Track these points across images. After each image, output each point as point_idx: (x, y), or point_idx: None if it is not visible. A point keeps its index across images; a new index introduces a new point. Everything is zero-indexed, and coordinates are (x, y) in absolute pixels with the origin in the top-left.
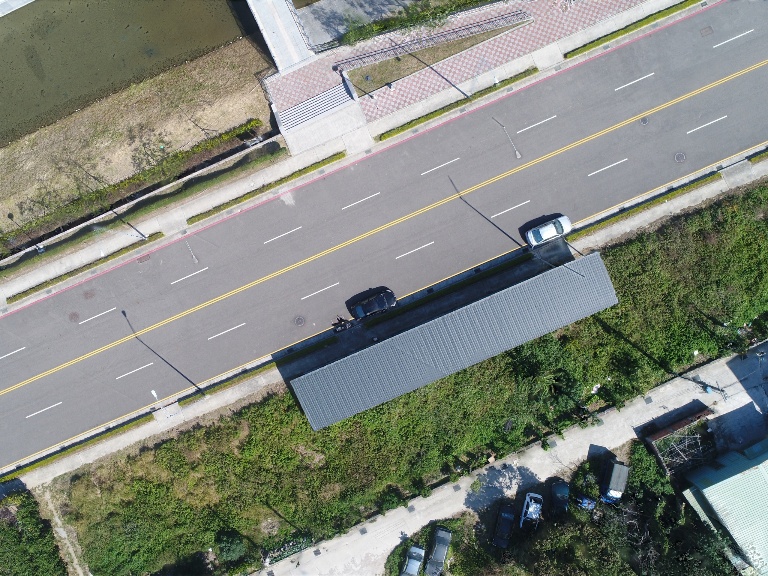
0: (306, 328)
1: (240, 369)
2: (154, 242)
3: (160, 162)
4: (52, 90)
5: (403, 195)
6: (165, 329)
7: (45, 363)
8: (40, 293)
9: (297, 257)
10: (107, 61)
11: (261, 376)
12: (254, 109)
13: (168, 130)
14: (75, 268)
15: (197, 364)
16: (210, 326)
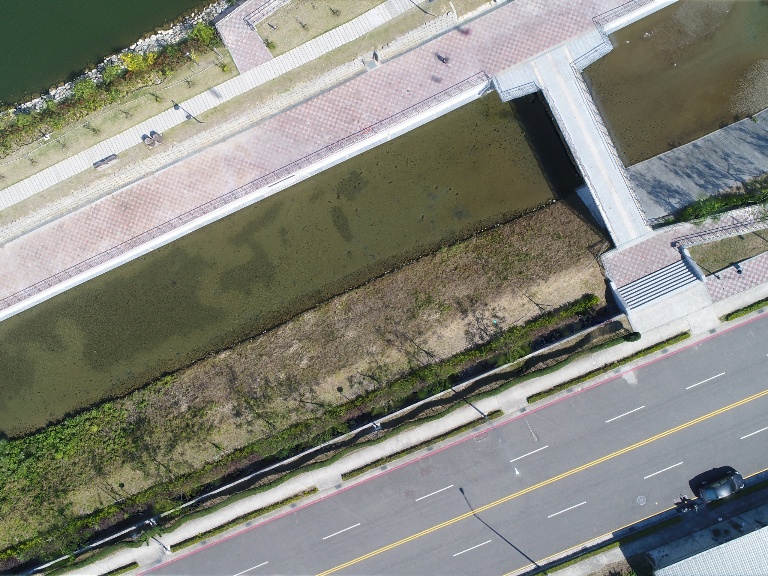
0: (648, 507)
1: (580, 547)
2: (492, 420)
3: (493, 337)
4: (359, 251)
5: (749, 375)
6: (504, 507)
7: (381, 540)
8: (375, 469)
9: (640, 436)
10: (415, 222)
11: (602, 555)
12: (589, 284)
13: (502, 305)
14: (412, 445)
15: (536, 542)
16: (550, 504)
